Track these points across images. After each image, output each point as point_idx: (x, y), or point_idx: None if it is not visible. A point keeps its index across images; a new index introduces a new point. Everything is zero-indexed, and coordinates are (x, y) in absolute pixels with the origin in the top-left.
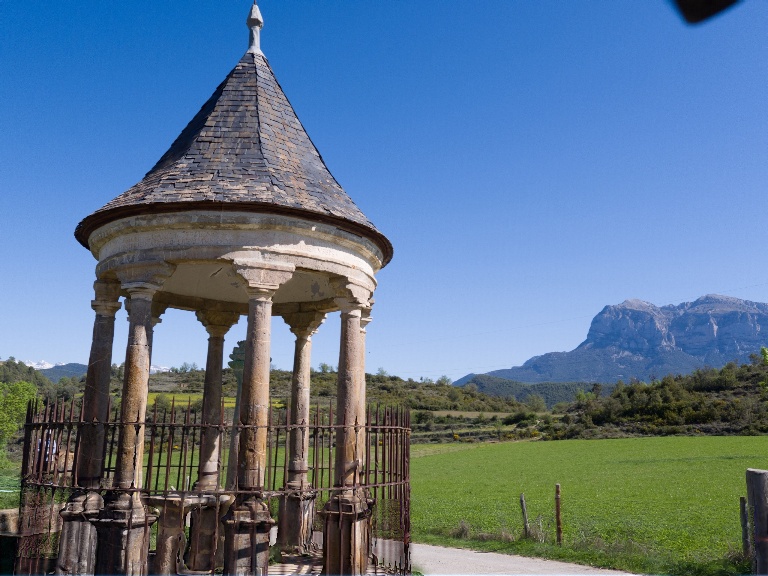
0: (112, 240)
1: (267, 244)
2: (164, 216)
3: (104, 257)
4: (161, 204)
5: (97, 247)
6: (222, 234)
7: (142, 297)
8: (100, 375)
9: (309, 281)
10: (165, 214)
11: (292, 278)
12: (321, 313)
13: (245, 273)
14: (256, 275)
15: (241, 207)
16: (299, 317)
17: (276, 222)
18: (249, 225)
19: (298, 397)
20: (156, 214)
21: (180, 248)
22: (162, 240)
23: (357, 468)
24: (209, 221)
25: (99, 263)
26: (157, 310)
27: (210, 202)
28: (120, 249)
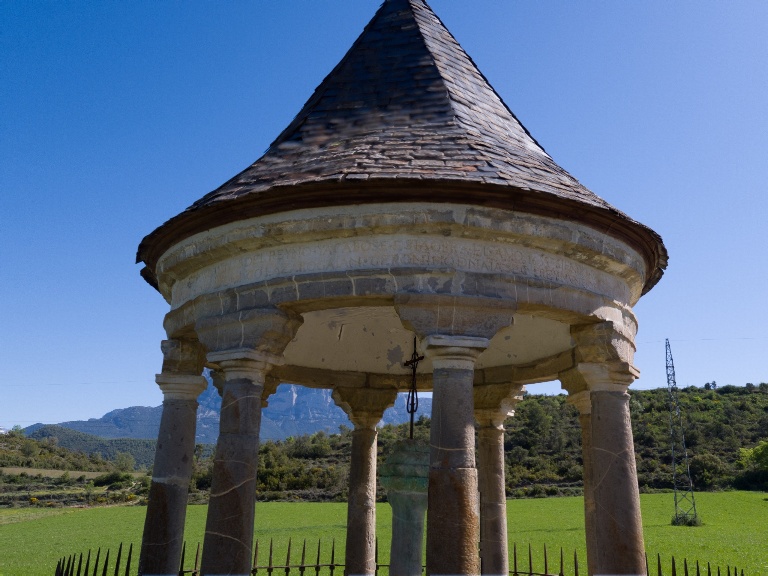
0: (364, 237)
1: (622, 301)
2: (527, 219)
3: (320, 266)
4: (536, 196)
5: (276, 240)
6: (586, 272)
7: (471, 367)
8: (250, 512)
9: (386, 343)
10: (529, 215)
11: (359, 334)
12: (398, 392)
13: (618, 346)
14: (625, 351)
15: (625, 234)
16: (368, 395)
17: (638, 268)
18: (618, 265)
19: (368, 522)
20: (513, 211)
21: (545, 284)
22: (506, 262)
23: None
24: (592, 246)
25: (302, 276)
26: (200, 365)
27: (603, 214)
28: (399, 260)
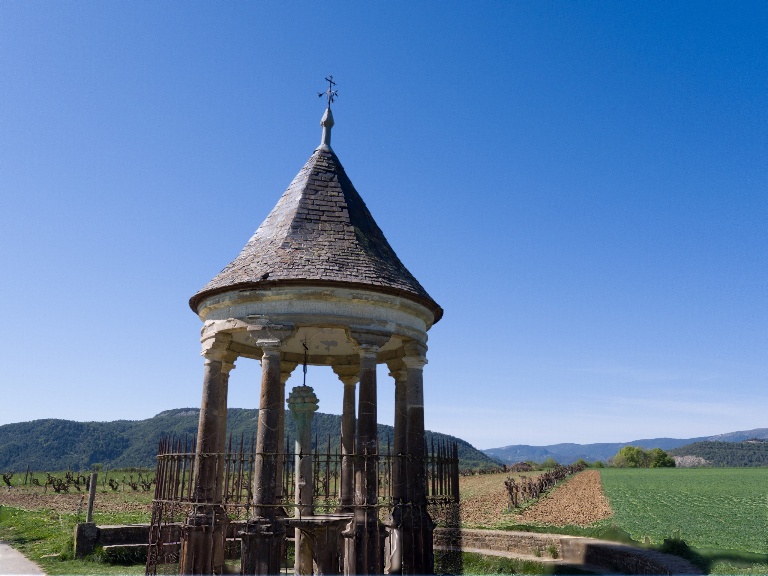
0: None
1: None
2: None
3: None
4: None
5: None
6: None
7: None
8: None
9: None
10: None
11: None
12: None
13: None
14: None
15: None
16: None
17: None
18: None
19: None
20: None
21: None
22: None
23: None
24: None
25: None
26: None
27: None
28: None
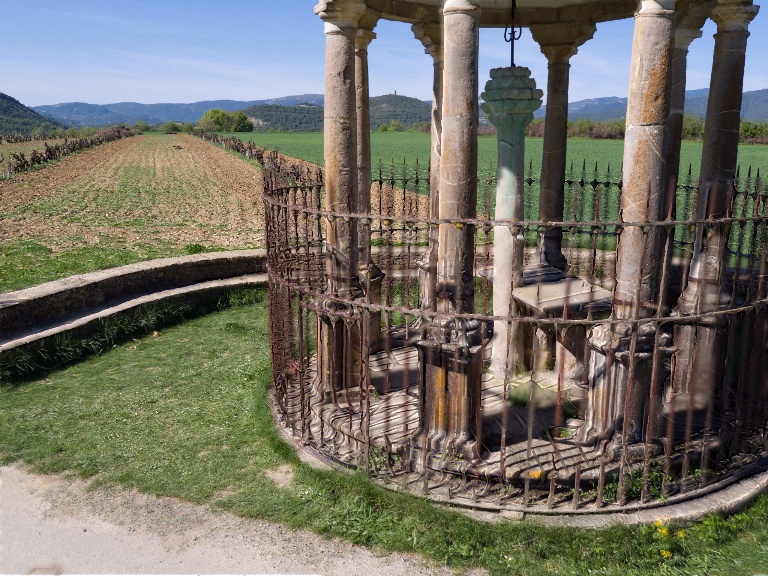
0: None
1: None
2: None
3: None
4: None
5: None
6: None
7: None
8: None
9: None
10: None
11: None
12: None
13: None
14: None
15: None
16: None
17: None
18: None
19: None
20: None
21: None
22: None
23: (327, 253)
24: None
25: None
26: None
27: None
28: None
